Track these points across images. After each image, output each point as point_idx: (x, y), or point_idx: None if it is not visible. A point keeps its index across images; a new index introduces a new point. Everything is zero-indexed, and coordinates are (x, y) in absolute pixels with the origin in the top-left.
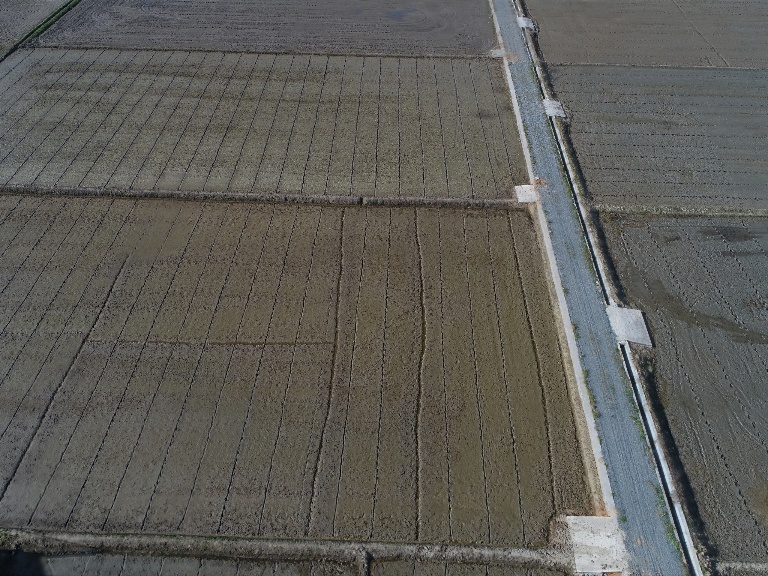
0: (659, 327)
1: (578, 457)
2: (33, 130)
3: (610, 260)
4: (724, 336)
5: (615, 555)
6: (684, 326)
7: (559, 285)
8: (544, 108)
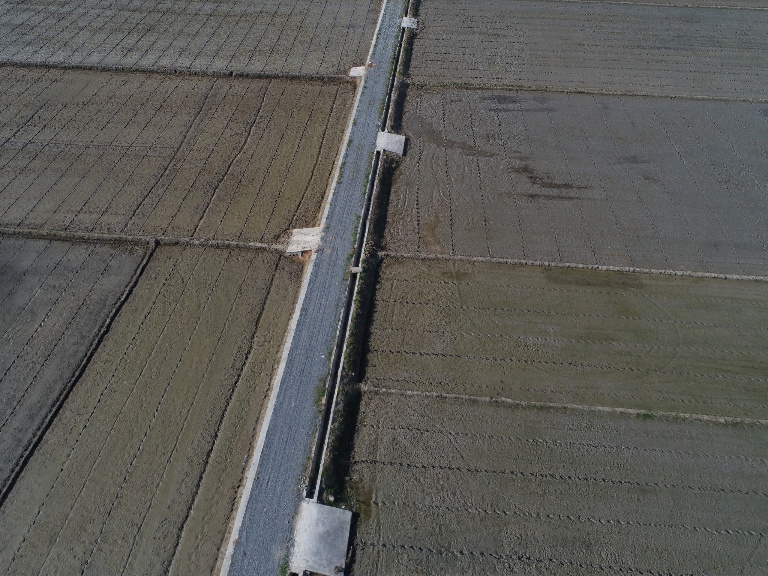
0: (415, 146)
1: (318, 205)
2: (0, 28)
3: (400, 110)
4: (459, 152)
5: (312, 243)
6: (434, 146)
7: (351, 120)
8: (401, 22)
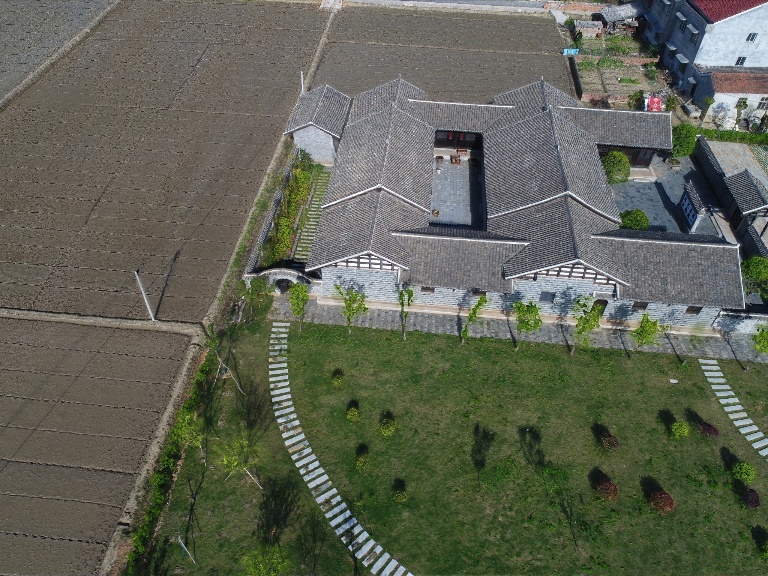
0: None
1: None
2: None
3: None
4: None
5: None
6: None
7: None
8: None
